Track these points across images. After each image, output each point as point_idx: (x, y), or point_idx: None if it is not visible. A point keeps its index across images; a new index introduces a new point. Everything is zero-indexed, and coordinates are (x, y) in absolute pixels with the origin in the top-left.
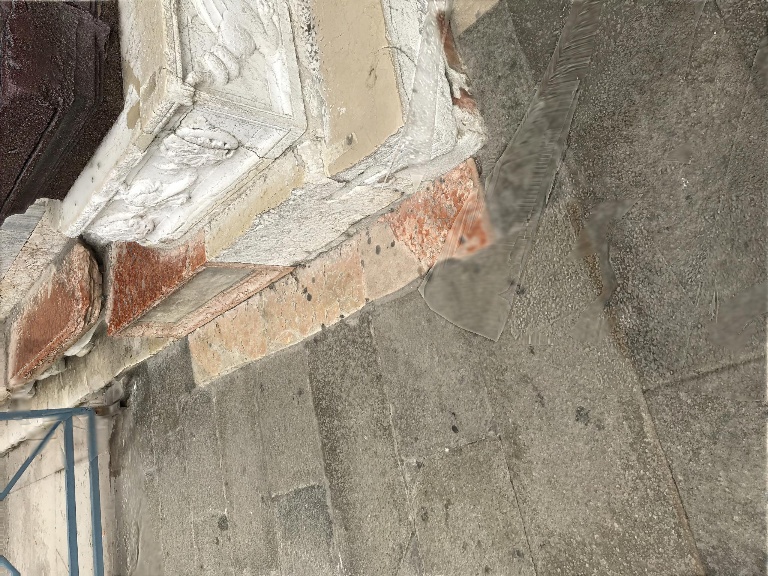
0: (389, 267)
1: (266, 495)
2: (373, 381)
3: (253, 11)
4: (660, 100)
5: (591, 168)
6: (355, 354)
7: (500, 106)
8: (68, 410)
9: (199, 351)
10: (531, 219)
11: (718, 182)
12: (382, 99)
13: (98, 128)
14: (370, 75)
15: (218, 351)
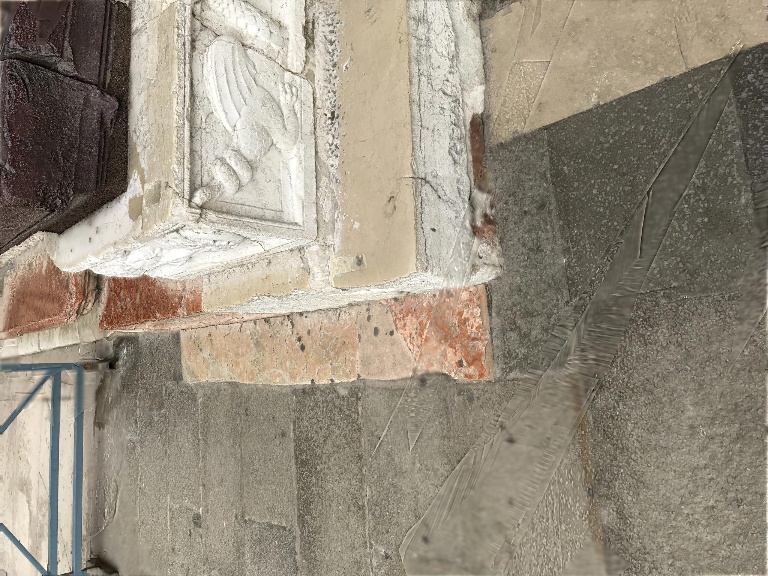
0: (385, 354)
1: (240, 514)
2: (354, 457)
3: (274, 102)
4: (675, 445)
5: (592, 483)
6: (340, 423)
7: (521, 243)
8: (57, 365)
9: (189, 351)
10: (521, 525)
11: (724, 427)
12: (398, 235)
13: (99, 199)
14: (389, 202)
15: (208, 359)
